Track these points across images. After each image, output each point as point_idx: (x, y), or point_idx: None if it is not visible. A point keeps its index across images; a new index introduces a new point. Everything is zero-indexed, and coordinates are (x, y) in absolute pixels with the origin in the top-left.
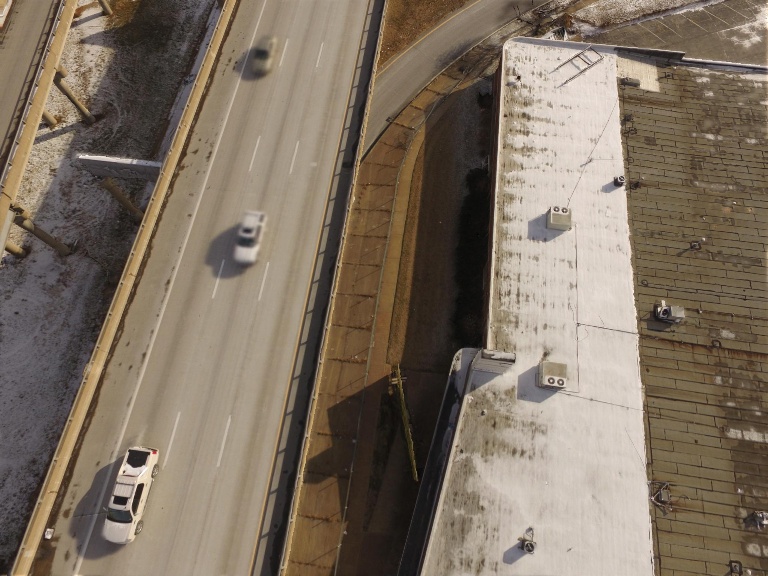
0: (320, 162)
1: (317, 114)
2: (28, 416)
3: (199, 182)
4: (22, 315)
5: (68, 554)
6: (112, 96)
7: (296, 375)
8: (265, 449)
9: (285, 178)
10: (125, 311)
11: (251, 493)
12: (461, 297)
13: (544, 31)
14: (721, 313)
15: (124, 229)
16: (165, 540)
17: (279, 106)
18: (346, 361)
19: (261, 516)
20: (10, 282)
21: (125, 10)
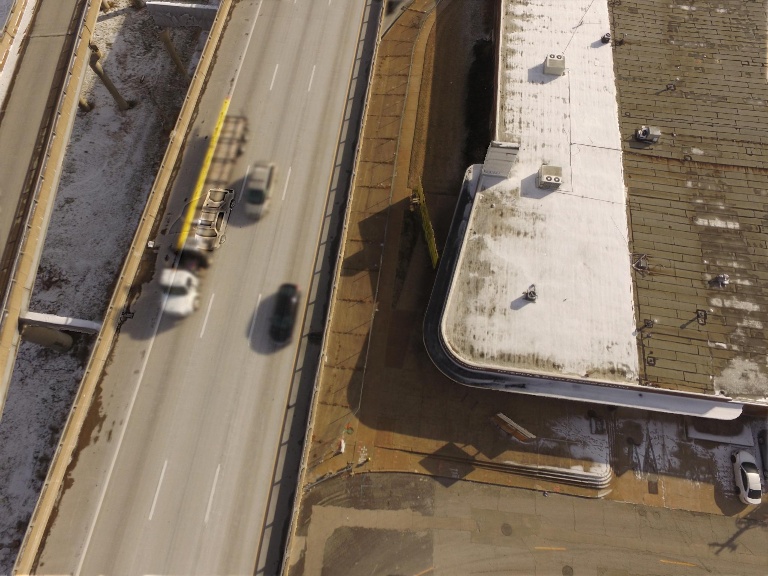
0: None
1: None
2: (101, 229)
3: (253, 11)
4: (91, 153)
5: (167, 257)
6: None
7: (342, 141)
8: (320, 188)
9: (325, 7)
10: (198, 100)
11: (311, 216)
12: (471, 136)
13: None
14: (692, 136)
15: (174, 91)
16: (244, 247)
17: None
18: (373, 187)
19: (319, 231)
20: (78, 129)
21: None
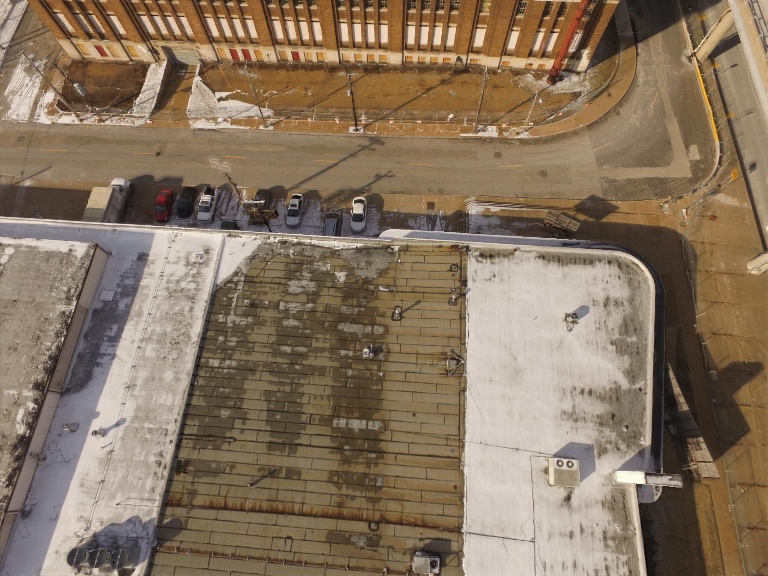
0: None
1: None
2: None
3: None
4: None
5: None
6: None
7: None
8: None
9: None
10: None
11: None
12: None
13: None
14: (361, 570)
15: None
16: None
17: None
18: (752, 485)
19: None
20: None
21: None
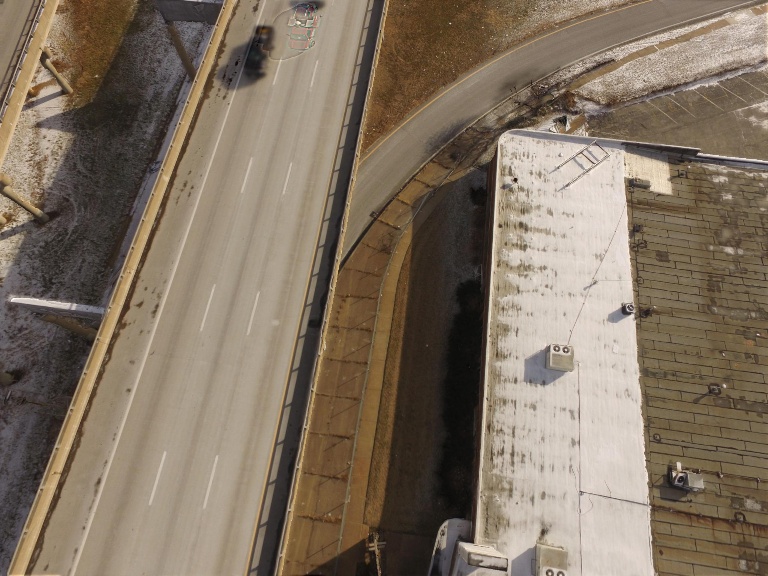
0: (283, 320)
1: (282, 256)
2: None
3: (142, 345)
4: None
5: None
6: (68, 190)
7: None
8: None
9: (241, 341)
10: (46, 521)
11: None
12: (449, 443)
13: (544, 111)
14: (745, 477)
15: (75, 350)
16: None
17: (238, 245)
18: (318, 519)
19: None
20: None
21: (87, 88)
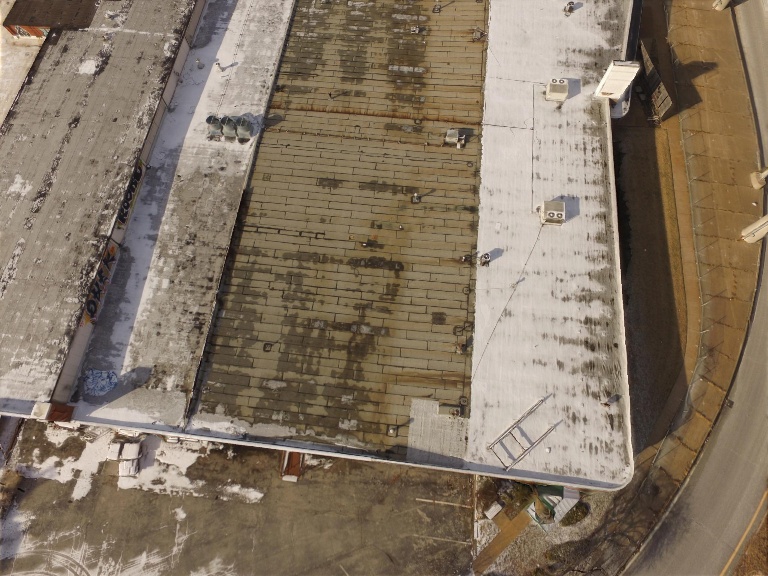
0: None
1: None
2: None
3: None
4: None
5: None
6: None
7: None
8: None
9: None
10: None
11: None
12: None
13: None
14: (409, 143)
15: None
16: None
17: None
18: (699, 132)
19: None
20: None
21: None
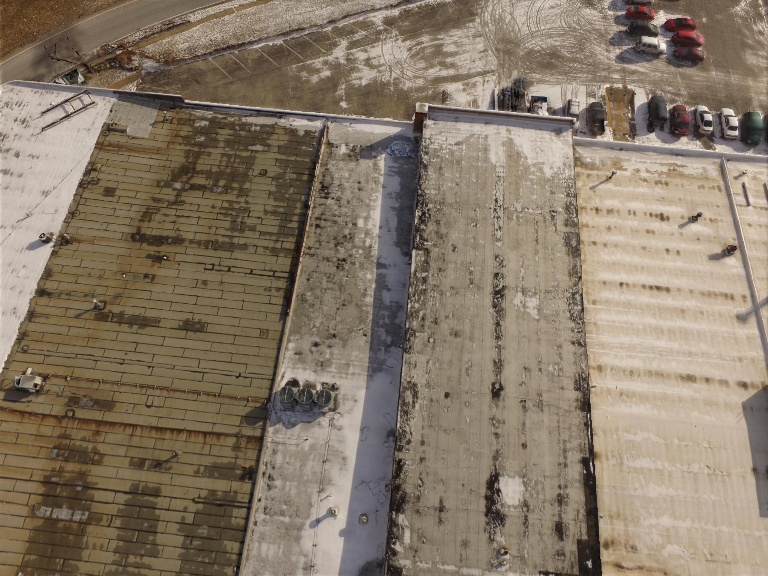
0: None
1: None
2: None
3: None
4: None
5: None
6: None
7: None
8: None
9: None
10: None
11: None
12: None
13: (100, 68)
14: (90, 379)
15: None
16: None
17: None
18: None
19: None
20: None
21: None
